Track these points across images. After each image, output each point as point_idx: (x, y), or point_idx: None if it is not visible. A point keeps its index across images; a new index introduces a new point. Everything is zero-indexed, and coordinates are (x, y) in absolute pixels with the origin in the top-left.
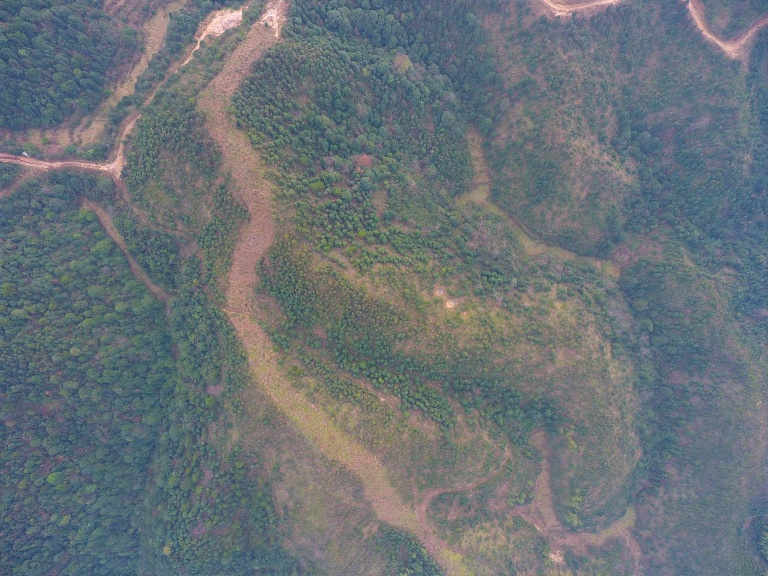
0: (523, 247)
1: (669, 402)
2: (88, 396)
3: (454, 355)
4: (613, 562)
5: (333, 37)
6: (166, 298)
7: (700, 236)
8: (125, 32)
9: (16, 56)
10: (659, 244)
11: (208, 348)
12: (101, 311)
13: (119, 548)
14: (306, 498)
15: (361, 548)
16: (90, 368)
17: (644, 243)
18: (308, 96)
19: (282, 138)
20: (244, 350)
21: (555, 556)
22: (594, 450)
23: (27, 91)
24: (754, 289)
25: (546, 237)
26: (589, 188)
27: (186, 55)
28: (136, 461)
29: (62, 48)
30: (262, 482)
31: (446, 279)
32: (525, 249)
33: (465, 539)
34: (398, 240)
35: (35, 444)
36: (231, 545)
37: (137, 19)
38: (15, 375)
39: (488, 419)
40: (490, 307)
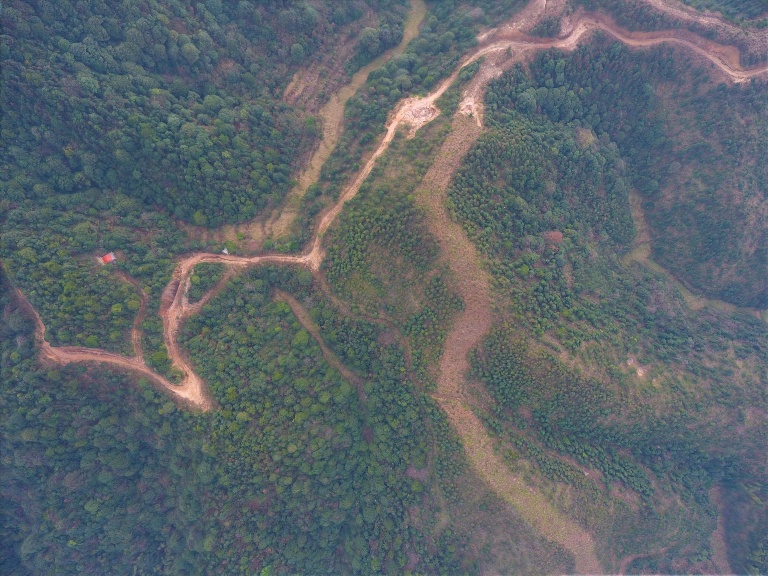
0: (686, 303)
1: None
2: (300, 490)
3: (651, 424)
4: None
5: (525, 119)
6: (357, 382)
7: None
8: (308, 122)
9: (220, 158)
10: None
11: (412, 433)
12: (309, 404)
13: None
14: None
15: None
16: (303, 462)
17: None
18: (504, 179)
19: (491, 226)
20: (460, 437)
21: None
22: None
23: (229, 191)
24: None
25: (709, 292)
26: (757, 244)
27: (378, 144)
28: (330, 545)
29: (256, 145)
30: (471, 564)
31: (634, 347)
32: (688, 304)
33: None
34: (594, 314)
35: (248, 540)
36: None
37: (314, 107)
38: (237, 477)
39: (679, 483)
40: (675, 371)
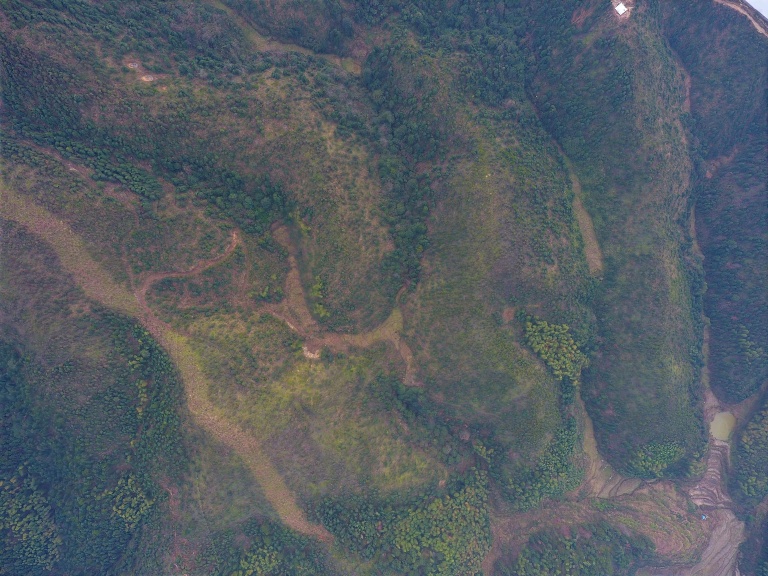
0: (254, 44)
1: (414, 192)
2: None
3: (148, 125)
4: (373, 358)
5: None
6: None
7: (432, 23)
8: None
9: None
10: (388, 31)
11: None
12: None
13: None
14: None
15: (70, 326)
16: None
17: (378, 34)
18: None
19: None
20: None
21: (312, 354)
22: (323, 231)
23: None
24: (493, 75)
25: (275, 32)
26: None
27: None
28: None
29: None
30: None
31: (142, 54)
32: (257, 46)
33: (194, 324)
34: (75, 6)
35: None
36: None
37: None
38: None
39: (204, 199)
40: (196, 85)
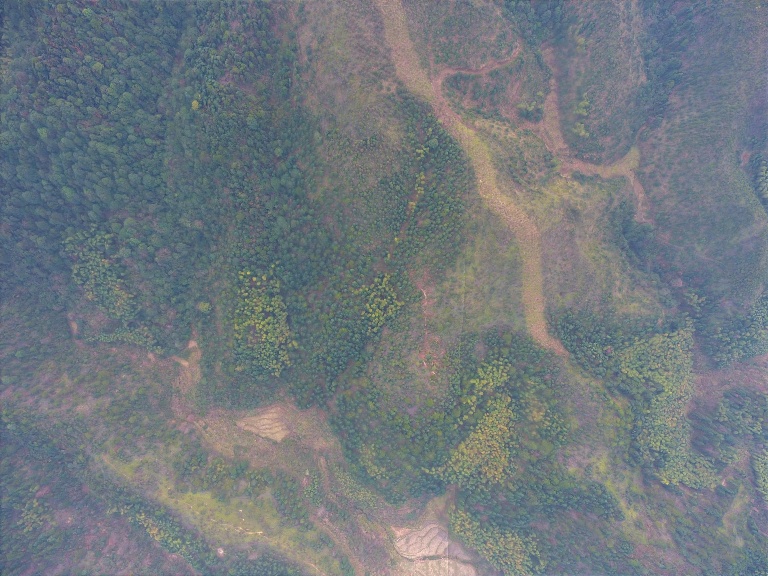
0: None
1: (672, 27)
2: None
3: None
4: (618, 186)
5: None
6: None
7: None
8: None
9: None
10: None
11: None
12: None
13: (147, 126)
14: (330, 26)
15: (380, 101)
16: None
17: None
18: None
19: None
20: None
21: None
22: (601, 46)
23: None
24: None
25: None
26: None
27: None
28: (165, 35)
29: None
30: (287, 26)
31: None
32: None
33: (478, 122)
34: None
35: None
36: (256, 110)
37: None
38: None
39: None
40: None
